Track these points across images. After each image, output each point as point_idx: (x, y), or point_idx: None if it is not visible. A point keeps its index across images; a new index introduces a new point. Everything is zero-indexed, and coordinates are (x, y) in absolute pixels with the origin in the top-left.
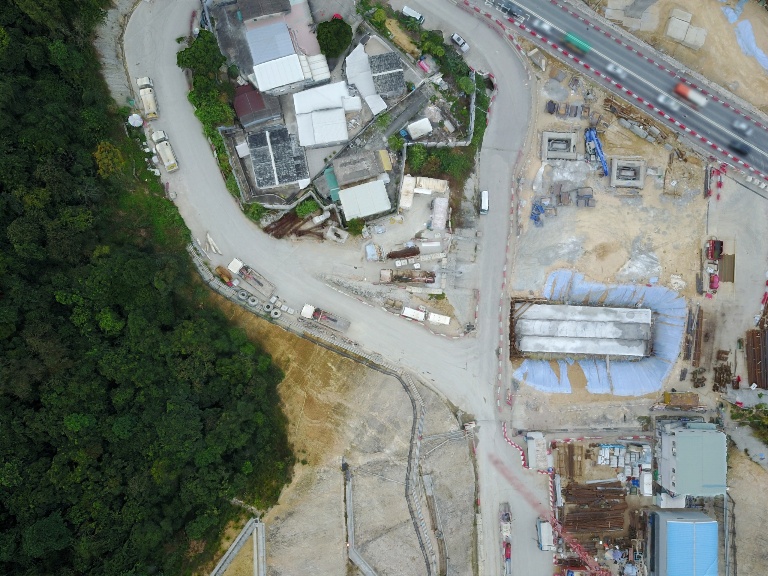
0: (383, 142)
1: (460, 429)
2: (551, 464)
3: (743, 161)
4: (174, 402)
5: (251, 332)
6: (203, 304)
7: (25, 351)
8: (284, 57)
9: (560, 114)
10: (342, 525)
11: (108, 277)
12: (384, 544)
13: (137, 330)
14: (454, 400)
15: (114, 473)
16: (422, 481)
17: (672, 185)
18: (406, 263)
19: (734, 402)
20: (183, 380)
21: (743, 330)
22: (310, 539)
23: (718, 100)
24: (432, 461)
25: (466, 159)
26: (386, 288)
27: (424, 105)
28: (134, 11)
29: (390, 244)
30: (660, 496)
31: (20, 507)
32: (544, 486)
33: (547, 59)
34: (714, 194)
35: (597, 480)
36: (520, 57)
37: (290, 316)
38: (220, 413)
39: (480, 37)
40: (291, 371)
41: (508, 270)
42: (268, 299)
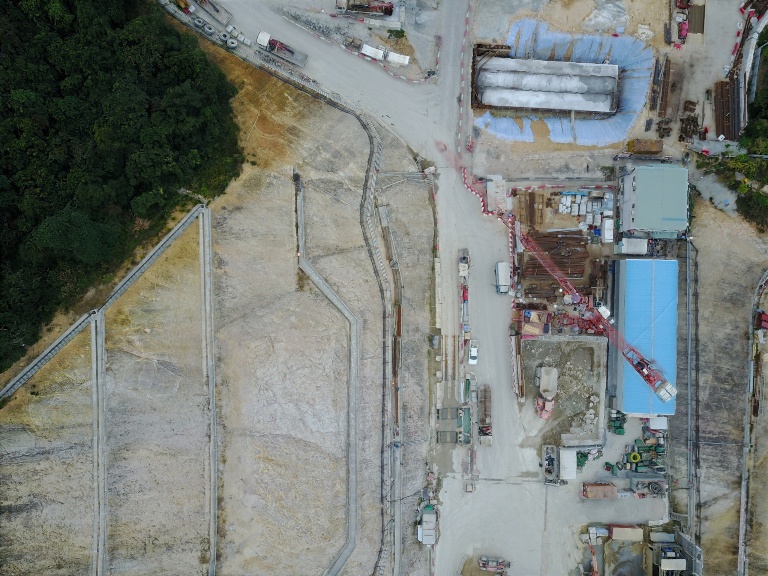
0: None
1: (419, 172)
2: (510, 207)
3: None
4: (120, 83)
5: (206, 55)
6: None
7: None
8: None
9: None
10: (293, 234)
11: None
12: (336, 262)
13: (85, 19)
14: (414, 146)
15: (59, 142)
16: (378, 212)
17: None
18: None
19: (700, 151)
20: (130, 65)
21: (712, 82)
22: (259, 239)
23: None
24: (389, 195)
25: None
26: (344, 22)
27: None
28: None
29: None
30: (621, 242)
31: None
32: (504, 233)
33: None
34: None
35: (558, 229)
36: None
37: (247, 49)
38: None
39: None
40: (245, 92)
41: (471, 18)
42: (224, 28)
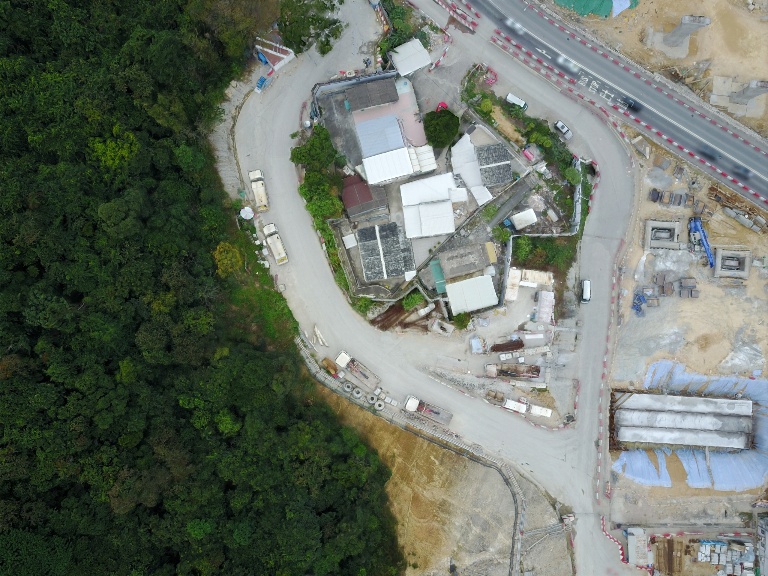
0: (487, 232)
1: (559, 522)
2: (652, 561)
3: None
4: (293, 509)
5: (357, 426)
6: (313, 400)
7: (153, 459)
8: (394, 150)
9: (664, 203)
10: None
11: (228, 380)
12: None
13: (255, 433)
14: (552, 491)
15: None
16: None
17: None
18: (511, 357)
19: None
20: (301, 485)
21: None
22: None
23: None
24: (533, 557)
25: (569, 249)
26: (489, 381)
27: (527, 194)
28: (245, 102)
29: (493, 336)
30: None
31: None
32: None
33: (651, 146)
34: None
35: None
36: (624, 144)
37: (393, 407)
38: (336, 518)
39: (583, 123)
40: (397, 467)
41: (608, 360)
42: (372, 391)
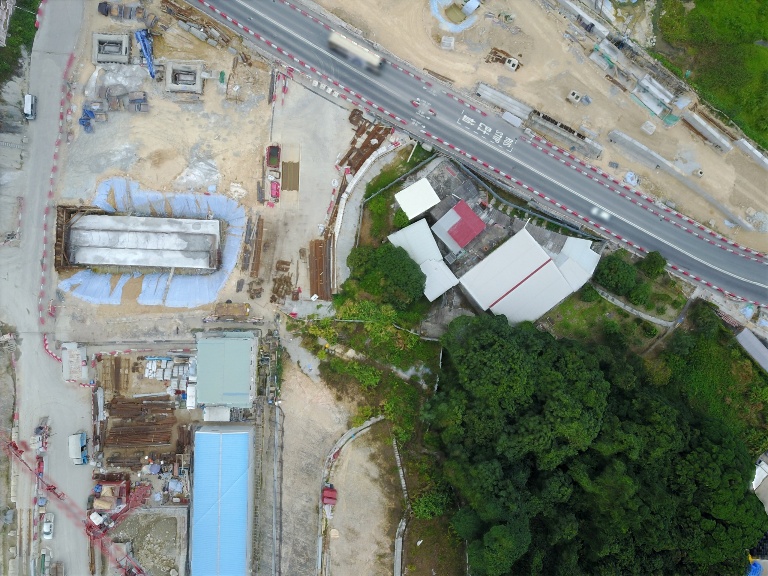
0: None
1: None
2: (86, 375)
3: (311, 65)
4: None
5: None
6: None
7: None
8: None
9: (114, 16)
10: None
11: None
12: None
13: None
14: None
15: None
16: None
17: (234, 90)
18: None
19: (289, 313)
20: None
21: (307, 240)
22: None
23: (284, 1)
24: None
25: (1, 60)
26: None
27: None
28: None
29: None
30: (204, 409)
31: None
32: (87, 400)
33: None
34: (279, 100)
35: (145, 394)
36: None
37: None
38: None
39: None
40: None
41: (57, 178)
42: None
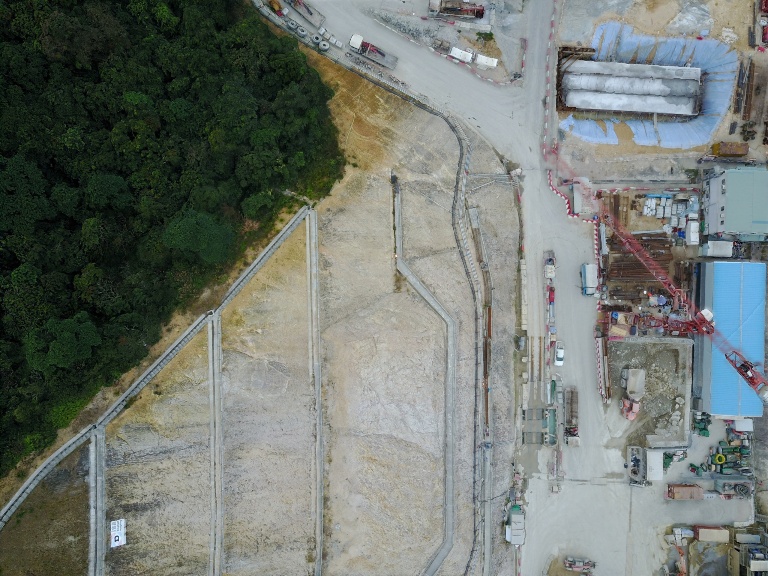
0: None
1: (505, 174)
2: (597, 209)
3: None
4: (229, 85)
5: None
6: None
7: (86, 21)
8: None
9: None
10: (390, 236)
11: None
12: (431, 263)
13: (192, 21)
14: (499, 149)
15: (172, 143)
16: (468, 214)
17: None
18: None
19: None
20: (238, 68)
21: None
22: (360, 240)
23: None
24: (478, 197)
25: None
26: (434, 25)
27: None
28: None
29: None
30: (707, 244)
31: (82, 171)
32: (589, 235)
33: None
34: None
35: (642, 231)
36: None
37: (338, 51)
38: None
39: None
40: (340, 94)
41: (556, 21)
42: (317, 30)
